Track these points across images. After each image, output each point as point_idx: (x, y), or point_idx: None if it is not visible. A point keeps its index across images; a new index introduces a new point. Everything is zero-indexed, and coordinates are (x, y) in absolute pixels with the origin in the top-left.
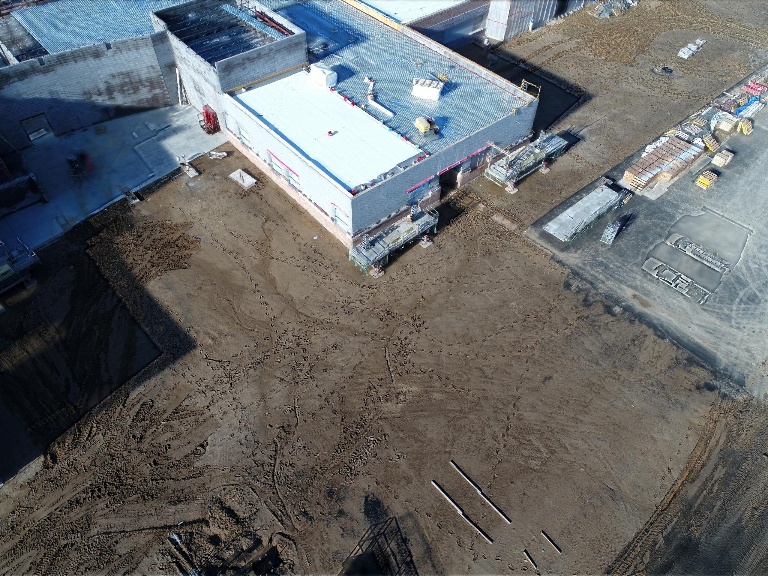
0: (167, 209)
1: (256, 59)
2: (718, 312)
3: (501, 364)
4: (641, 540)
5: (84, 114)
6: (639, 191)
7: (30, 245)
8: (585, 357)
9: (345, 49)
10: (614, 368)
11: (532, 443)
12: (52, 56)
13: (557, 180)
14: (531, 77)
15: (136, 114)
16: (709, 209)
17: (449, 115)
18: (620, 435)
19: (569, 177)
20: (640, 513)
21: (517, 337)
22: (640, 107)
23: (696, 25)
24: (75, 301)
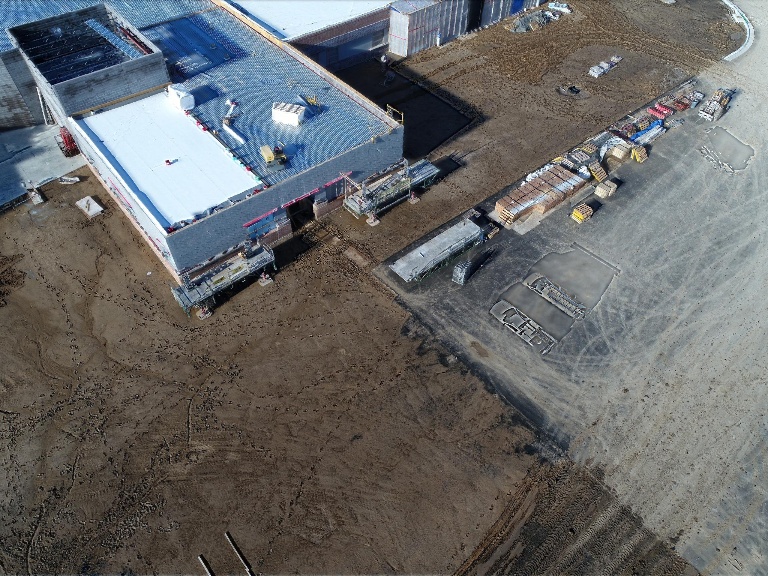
0: (0, 240)
1: (104, 81)
2: (559, 363)
3: (311, 420)
4: None
5: None
6: (508, 225)
7: None
8: (403, 413)
9: (217, 68)
10: (432, 426)
11: (321, 513)
12: None
13: (424, 211)
14: (426, 97)
15: None
16: (579, 246)
17: (304, 142)
18: (419, 505)
19: (438, 208)
20: None
21: (336, 389)
22: (534, 130)
23: (616, 41)
24: None
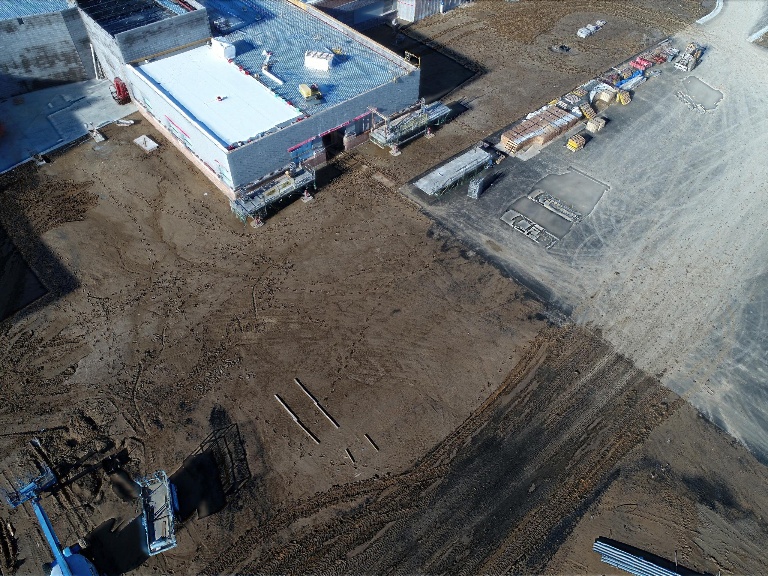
0: (71, 170)
1: (157, 32)
2: (561, 255)
3: (356, 300)
4: (451, 440)
5: (2, 86)
6: (513, 153)
7: None
8: (434, 293)
9: (251, 26)
10: (458, 302)
11: (371, 364)
12: None
13: (439, 144)
14: (434, 54)
15: (54, 87)
16: (574, 169)
17: (335, 83)
18: (451, 357)
19: (451, 142)
20: (455, 419)
21: (375, 277)
22: (531, 81)
23: (600, 8)
24: None
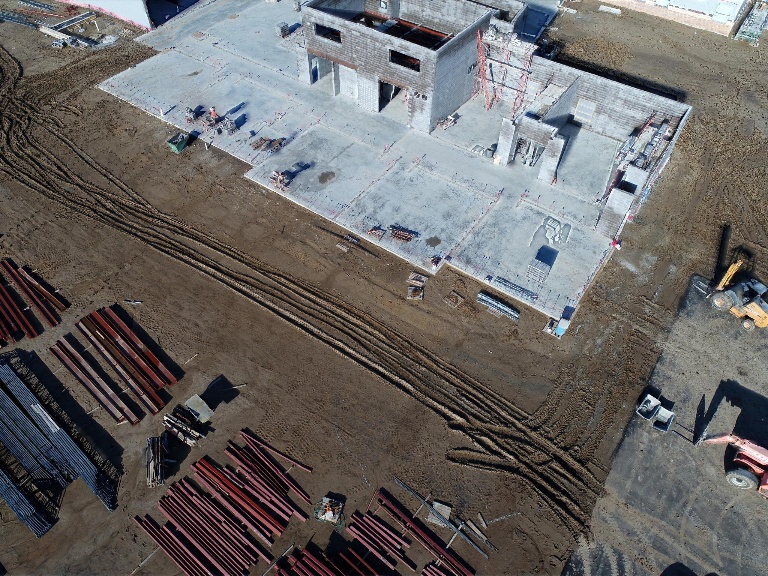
0: (580, 32)
1: None
2: None
3: None
4: None
5: None
6: None
7: None
8: None
9: None
10: None
11: None
12: None
13: None
14: None
15: None
16: None
17: None
18: None
19: None
20: None
21: None
22: None
23: None
24: None
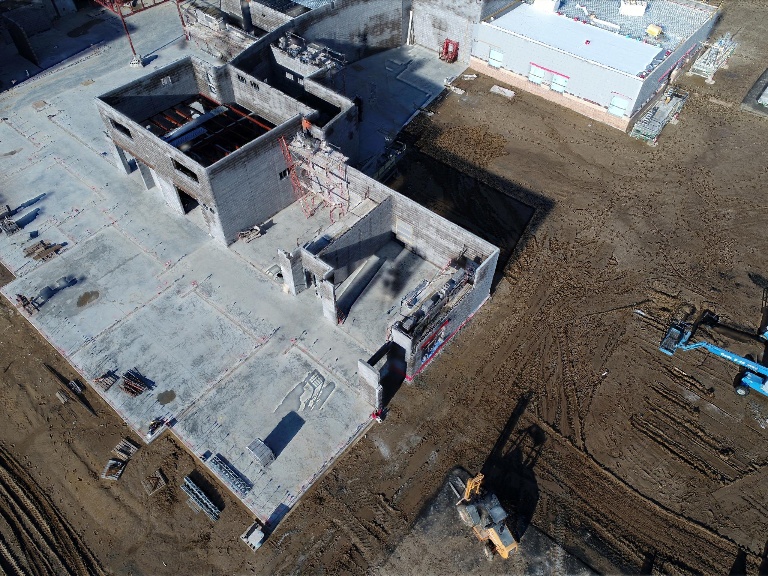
0: (459, 118)
1: None
2: None
3: None
4: None
5: None
6: None
7: (375, 150)
8: None
9: None
10: None
11: None
12: (340, 0)
13: (738, 72)
14: None
15: (376, 54)
16: None
17: None
18: None
19: (746, 70)
20: None
21: None
22: (763, 19)
23: None
24: (442, 183)
